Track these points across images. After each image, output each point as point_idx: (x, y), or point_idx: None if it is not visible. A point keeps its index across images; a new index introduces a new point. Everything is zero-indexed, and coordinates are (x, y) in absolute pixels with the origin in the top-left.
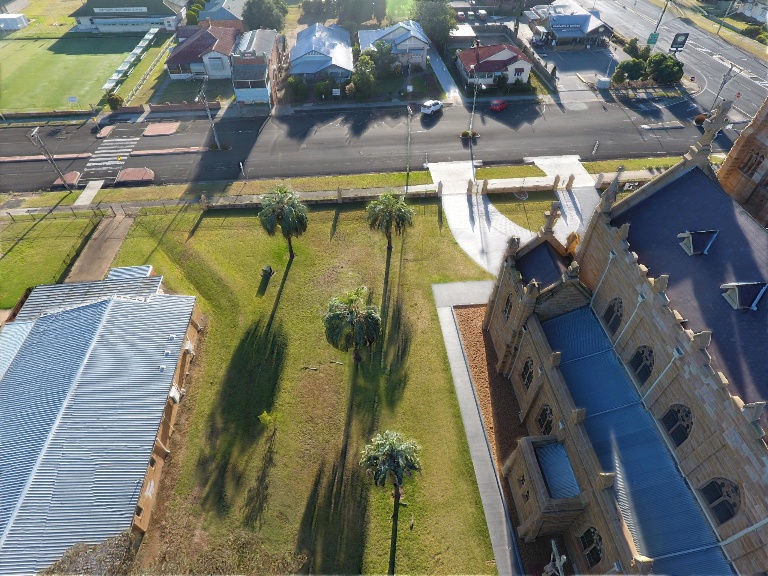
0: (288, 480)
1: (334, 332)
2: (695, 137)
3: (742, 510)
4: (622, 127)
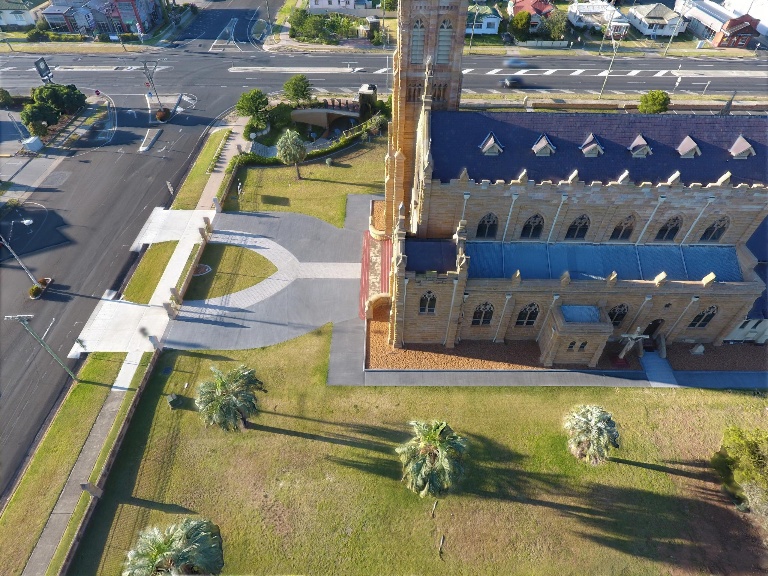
0: (586, 571)
1: (457, 476)
2: (181, 130)
3: (640, 220)
4: (131, 162)
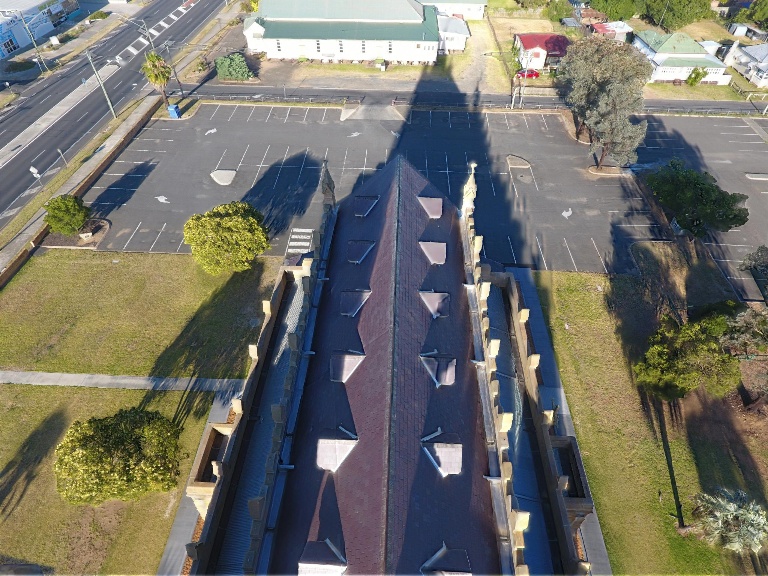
0: None
1: None
2: None
3: None
4: None
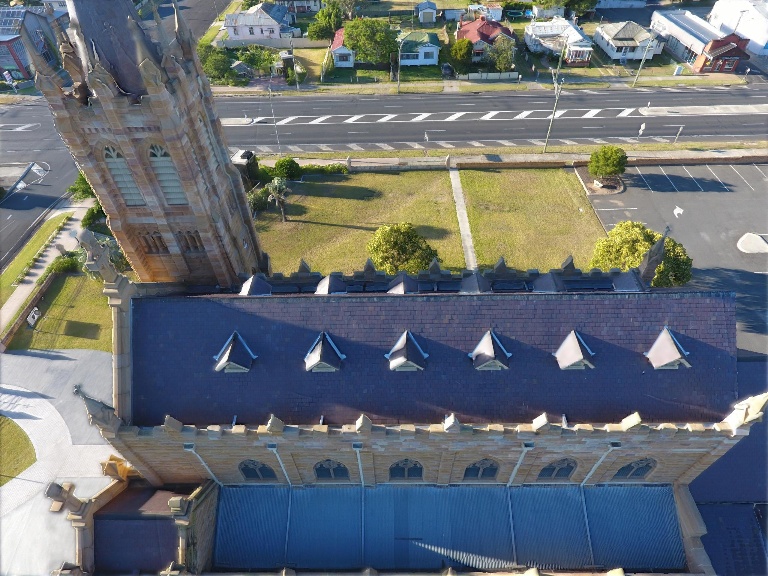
0: None
1: None
2: (10, 217)
3: (503, 464)
4: None
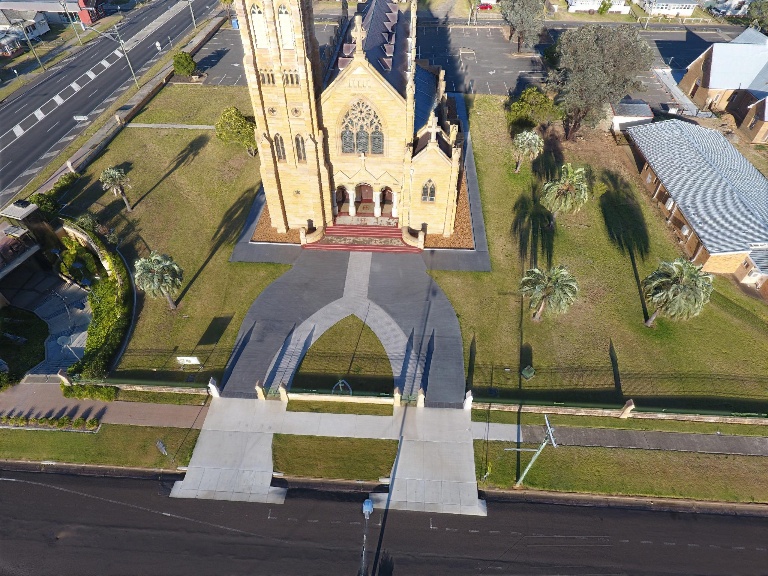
0: None
1: None
2: None
3: None
4: None
